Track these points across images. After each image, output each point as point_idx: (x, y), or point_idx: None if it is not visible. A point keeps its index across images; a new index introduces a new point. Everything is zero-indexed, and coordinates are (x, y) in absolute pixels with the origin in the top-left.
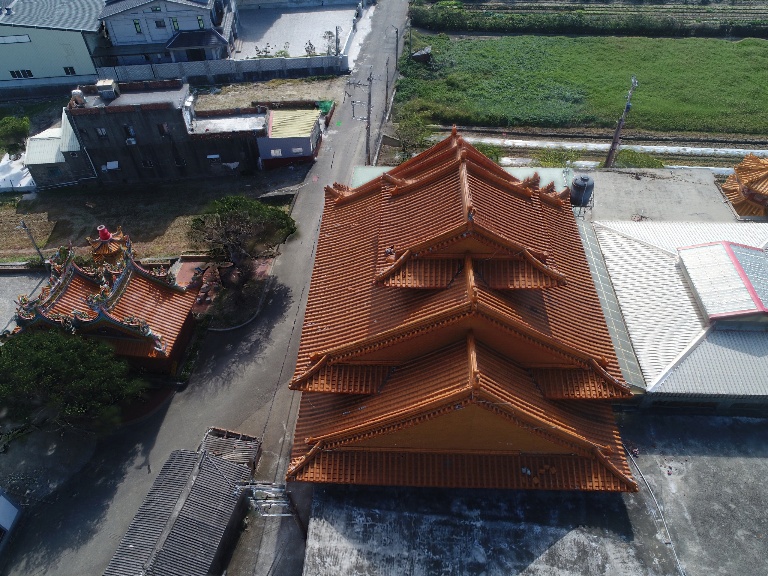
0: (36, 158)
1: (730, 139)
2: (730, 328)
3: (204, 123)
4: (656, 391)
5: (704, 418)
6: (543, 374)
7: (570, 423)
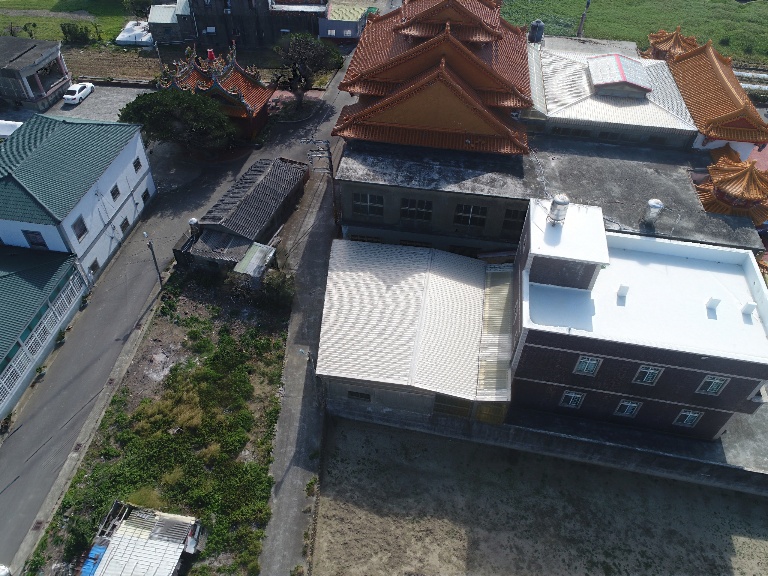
0: (157, 19)
1: None
2: (606, 94)
3: (280, 7)
4: (552, 116)
5: (582, 142)
6: (485, 93)
7: None
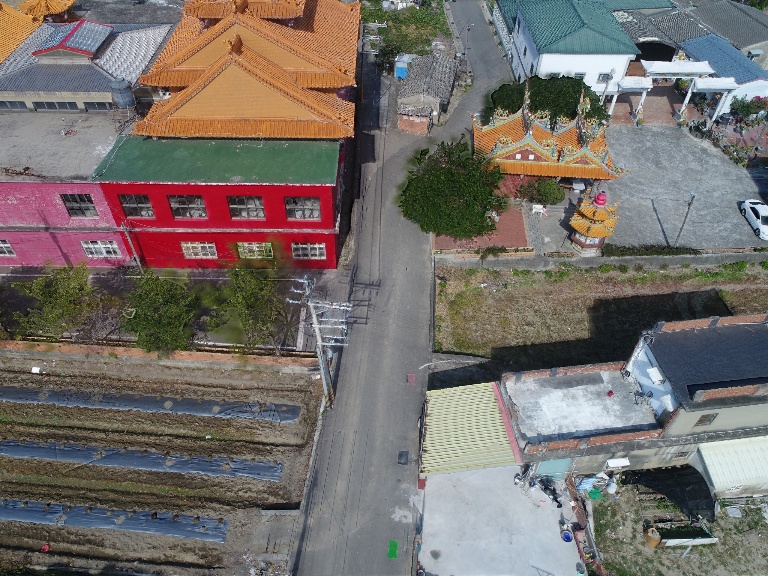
0: None
1: None
2: None
3: (630, 415)
4: None
5: None
6: None
7: None
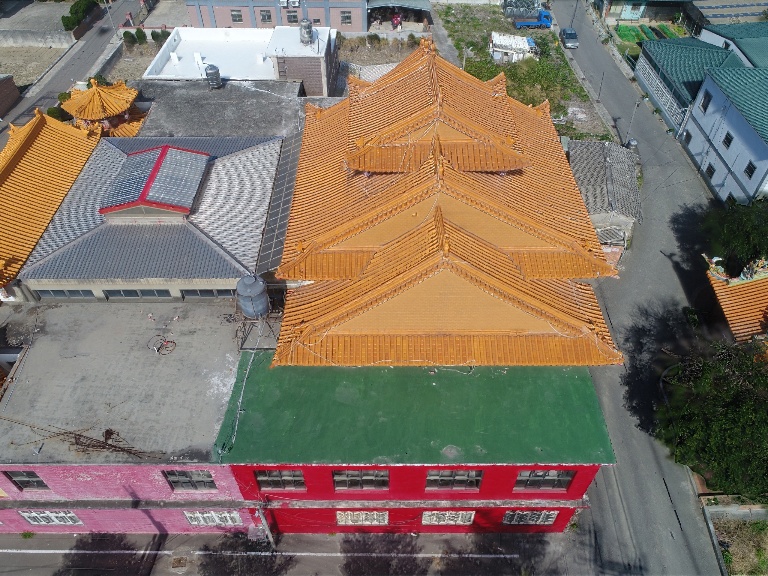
0: None
1: None
2: None
3: None
4: None
5: None
6: None
7: None
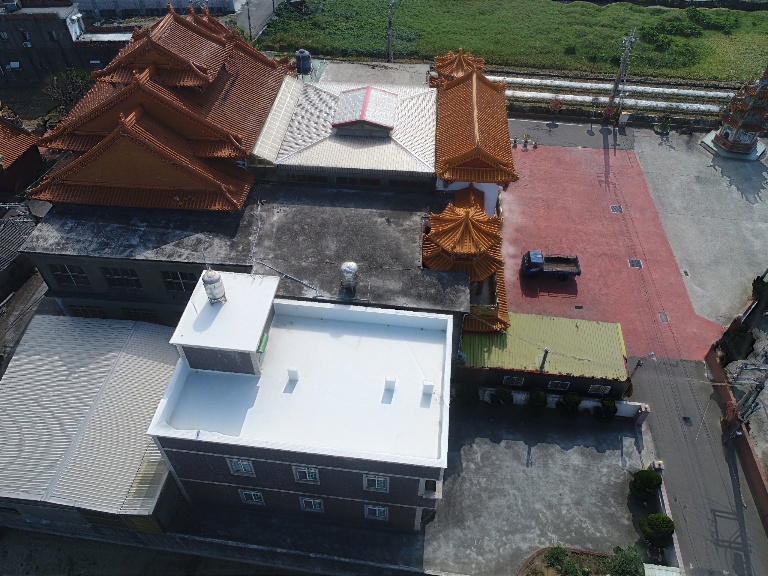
0: None
1: (521, 71)
2: (347, 134)
3: (91, 36)
4: (280, 163)
5: (320, 189)
6: (198, 143)
7: (210, 173)
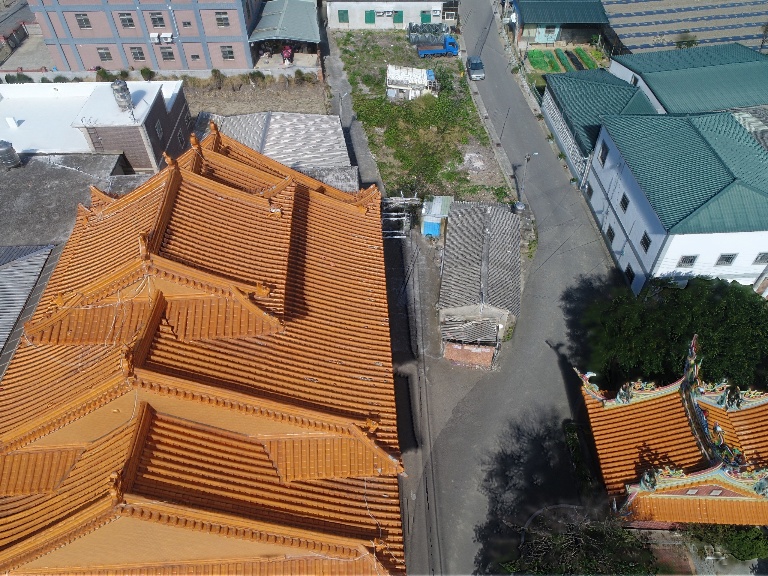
0: None
1: None
2: None
3: None
4: None
5: None
6: None
7: None
